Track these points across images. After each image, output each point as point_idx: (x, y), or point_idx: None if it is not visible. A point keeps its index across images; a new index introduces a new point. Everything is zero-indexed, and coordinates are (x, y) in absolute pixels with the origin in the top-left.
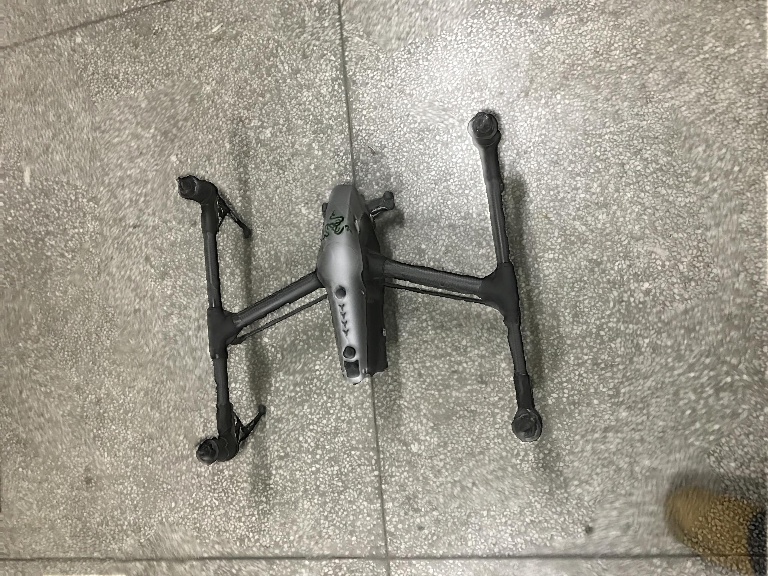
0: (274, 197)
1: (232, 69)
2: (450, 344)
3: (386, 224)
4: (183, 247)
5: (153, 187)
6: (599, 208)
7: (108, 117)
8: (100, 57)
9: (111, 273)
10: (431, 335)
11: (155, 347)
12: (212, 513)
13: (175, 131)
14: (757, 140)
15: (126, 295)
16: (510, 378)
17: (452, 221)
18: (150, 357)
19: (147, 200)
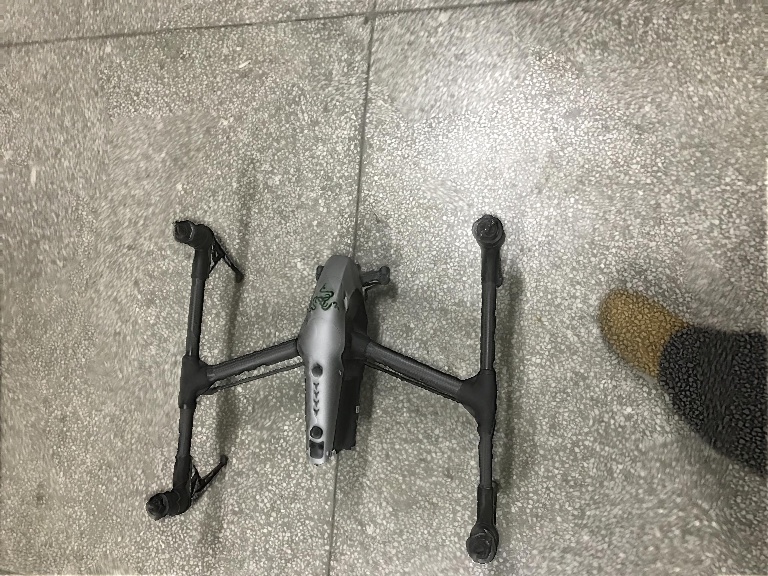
0: (272, 246)
1: (252, 109)
2: (422, 430)
3: (379, 295)
4: (173, 279)
5: (154, 212)
6: (594, 321)
7: (121, 133)
8: (124, 71)
9: (98, 292)
10: (405, 417)
11: (129, 375)
12: (157, 555)
13: (185, 160)
14: (765, 284)
15: (109, 316)
16: (477, 477)
17: (445, 306)
18: (122, 384)
19: (146, 224)
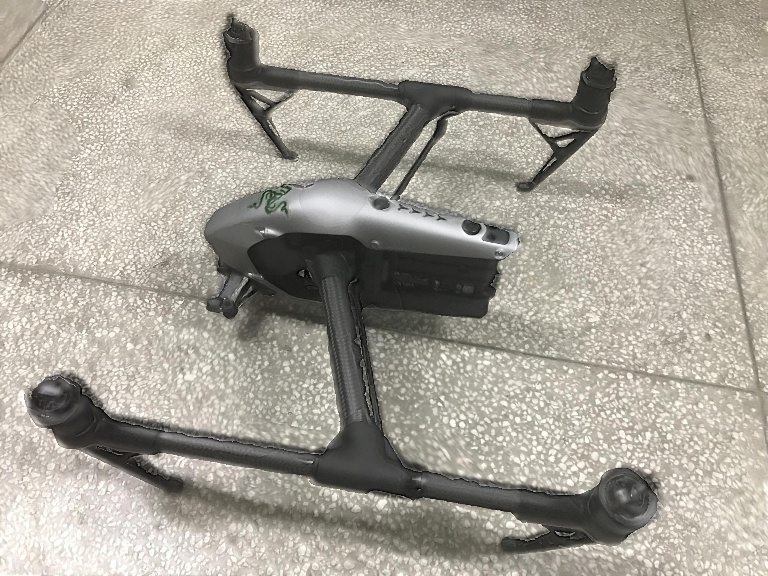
0: (139, 420)
1: None
2: None
3: None
4: None
5: None
6: None
7: None
8: None
9: None
10: None
11: None
12: None
13: None
14: (344, 6)
15: None
16: (515, 201)
17: None
18: None
19: None
